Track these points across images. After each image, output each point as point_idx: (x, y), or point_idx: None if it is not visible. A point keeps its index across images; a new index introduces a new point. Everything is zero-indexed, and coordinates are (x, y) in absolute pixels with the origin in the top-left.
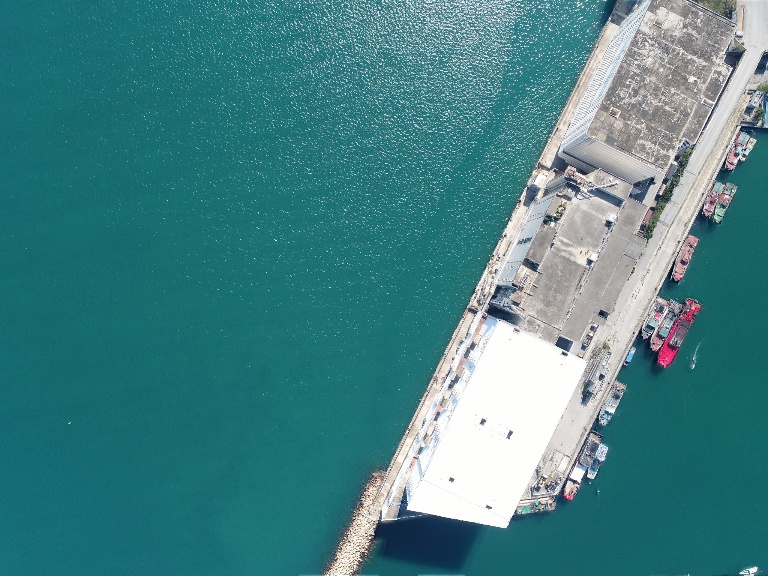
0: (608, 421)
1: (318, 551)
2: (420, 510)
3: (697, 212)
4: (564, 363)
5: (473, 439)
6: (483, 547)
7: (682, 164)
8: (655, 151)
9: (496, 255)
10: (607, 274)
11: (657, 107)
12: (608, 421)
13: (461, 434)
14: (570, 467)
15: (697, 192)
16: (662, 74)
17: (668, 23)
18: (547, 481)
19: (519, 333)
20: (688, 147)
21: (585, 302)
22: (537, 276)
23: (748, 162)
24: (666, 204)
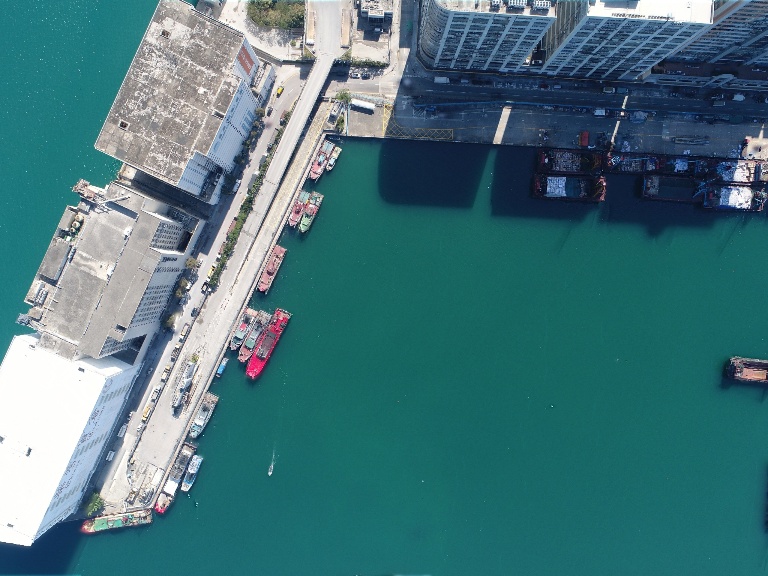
0: (199, 433)
1: None
2: None
3: (284, 222)
4: (83, 379)
5: None
6: (82, 561)
7: (259, 174)
8: (167, 164)
9: None
10: (123, 289)
11: (167, 119)
12: (199, 433)
13: None
14: (164, 480)
15: (283, 201)
16: (171, 85)
17: (175, 34)
18: None
19: (35, 349)
20: (269, 156)
21: (101, 317)
22: (57, 291)
23: (337, 171)
24: (249, 214)
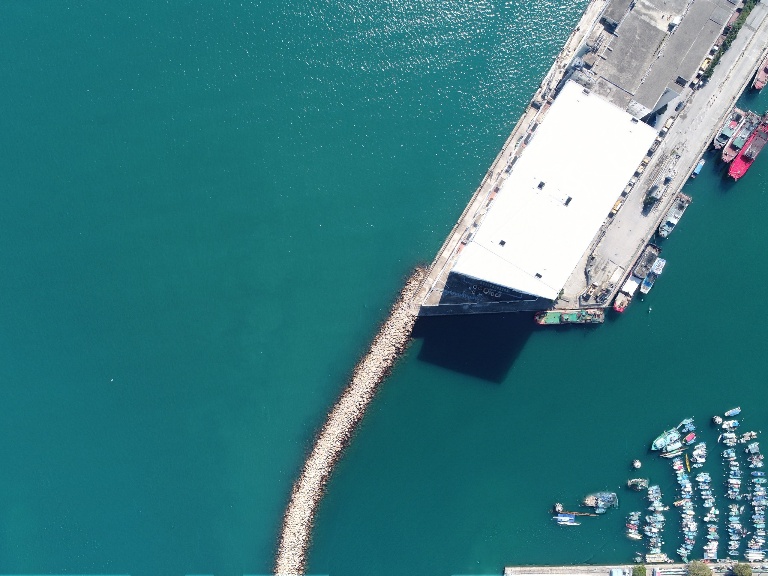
0: (668, 233)
1: (353, 344)
2: (467, 272)
3: None
4: (633, 131)
5: (529, 203)
6: (523, 356)
7: None
8: None
9: (566, 49)
10: (689, 39)
11: None
12: (668, 233)
13: (517, 196)
14: (623, 279)
15: None
16: None
17: None
18: (597, 292)
19: (588, 95)
20: None
21: (662, 67)
22: (613, 39)
23: None
24: (754, 6)
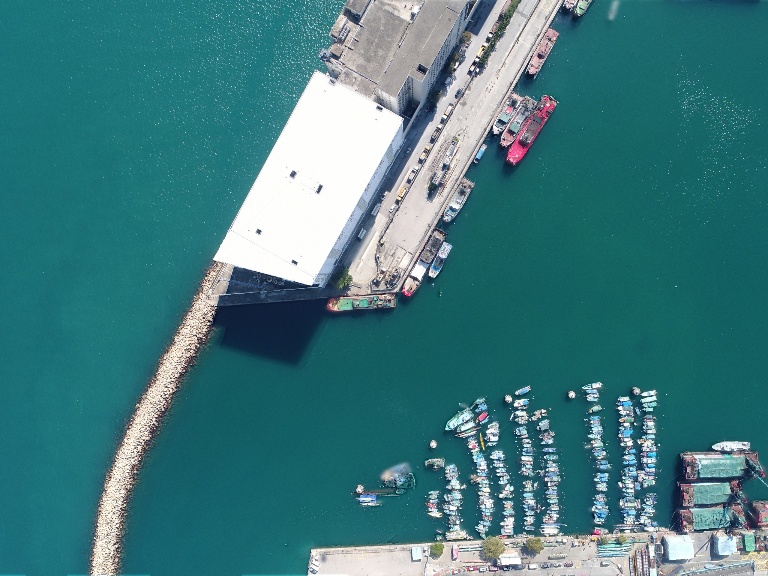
0: (452, 218)
1: (159, 336)
2: (226, 261)
3: (559, 5)
4: (379, 118)
5: (283, 191)
6: (321, 342)
7: None
8: None
9: None
10: (428, 27)
11: None
12: (452, 218)
13: (271, 185)
14: (412, 264)
15: None
16: None
17: None
18: (387, 277)
19: (335, 85)
20: None
21: (404, 56)
22: (359, 30)
23: None
24: None
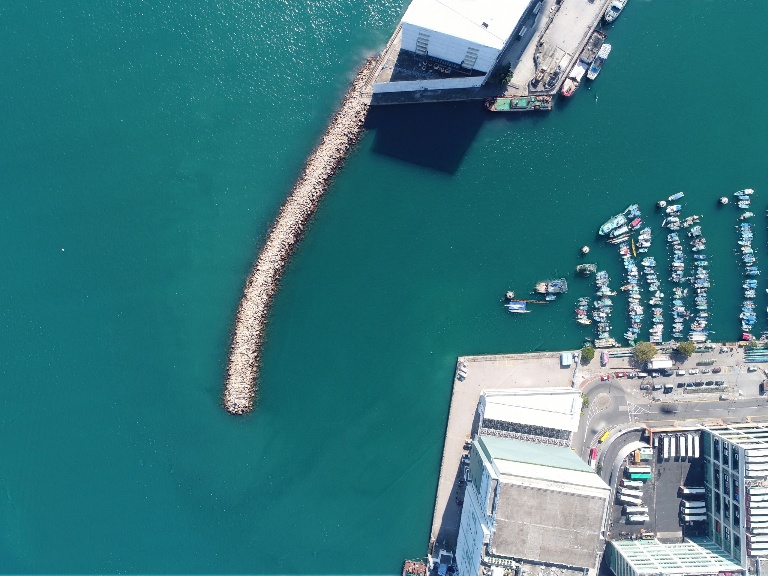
0: (614, 19)
1: (305, 138)
2: (414, 22)
3: None
4: None
5: None
6: (474, 146)
7: None
8: None
9: None
10: None
11: None
12: (614, 19)
13: None
14: (570, 66)
15: None
16: None
17: None
18: (545, 78)
19: None
20: None
21: None
22: None
23: None
24: None
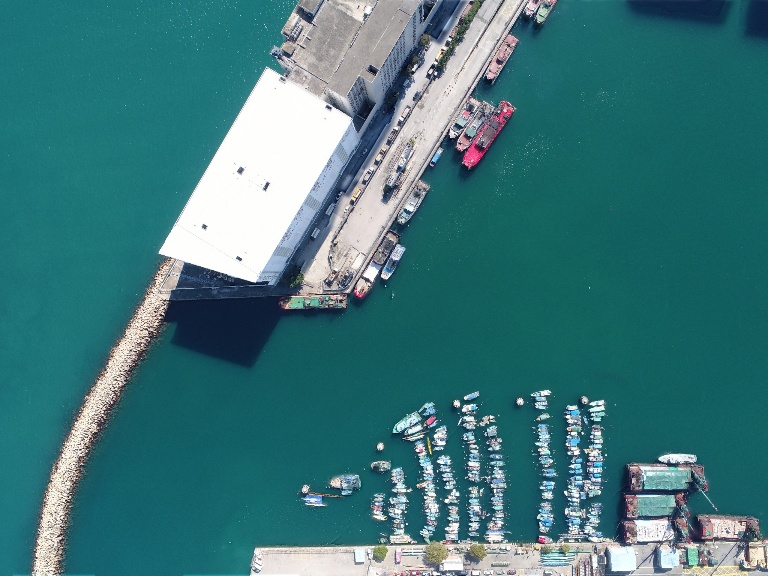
0: (406, 220)
1: (111, 328)
2: (171, 255)
3: (519, 11)
4: (328, 118)
5: (230, 187)
6: (272, 340)
7: None
8: None
9: None
10: (380, 29)
11: None
12: (406, 220)
13: (218, 181)
14: (364, 265)
15: None
16: None
17: None
18: None
19: (285, 83)
20: None
21: (355, 56)
22: (312, 28)
23: None
24: None
